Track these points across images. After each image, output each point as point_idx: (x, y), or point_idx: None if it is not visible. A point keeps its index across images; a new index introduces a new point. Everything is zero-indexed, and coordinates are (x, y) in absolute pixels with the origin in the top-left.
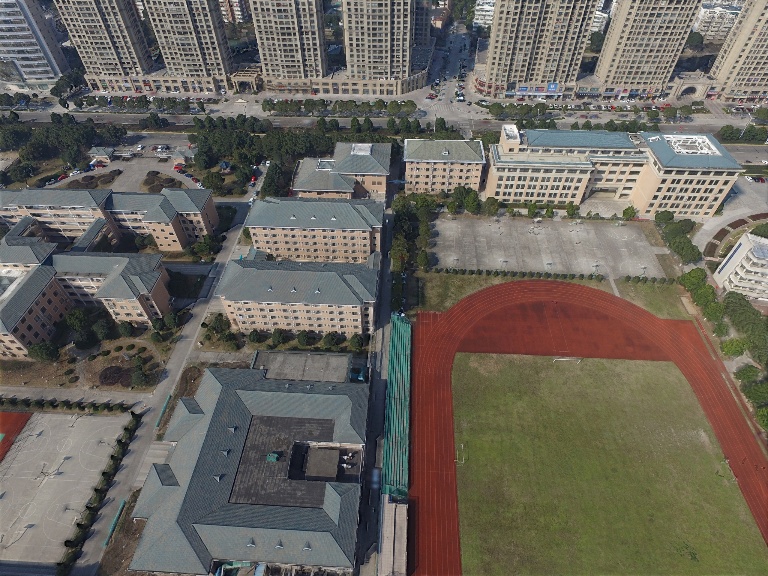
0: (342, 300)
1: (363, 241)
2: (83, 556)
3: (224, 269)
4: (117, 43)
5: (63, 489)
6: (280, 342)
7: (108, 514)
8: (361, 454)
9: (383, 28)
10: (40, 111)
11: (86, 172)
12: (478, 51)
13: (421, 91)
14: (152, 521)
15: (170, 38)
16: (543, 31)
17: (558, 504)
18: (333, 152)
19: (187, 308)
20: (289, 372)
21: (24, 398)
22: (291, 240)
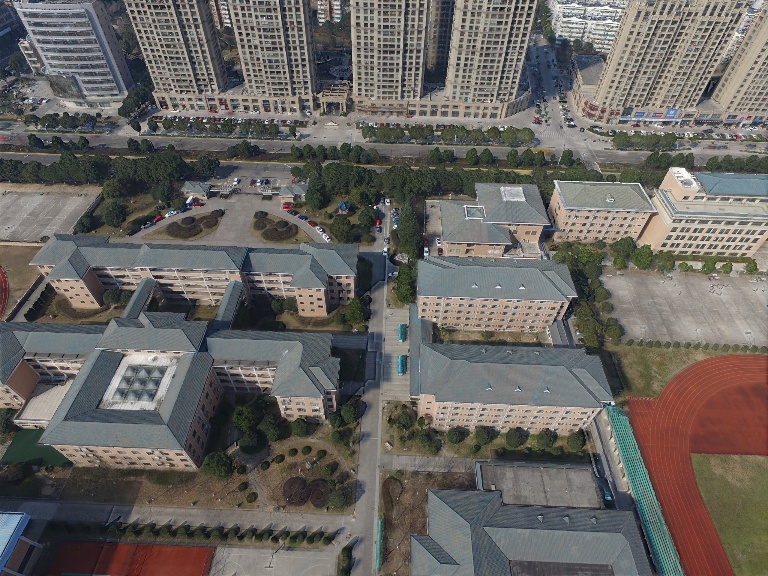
0: (577, 401)
1: (550, 311)
2: None
3: (383, 341)
4: (194, 58)
5: None
6: (486, 443)
7: None
8: None
9: (498, 48)
10: (107, 134)
11: (183, 212)
12: (579, 69)
13: (524, 114)
14: None
15: (256, 54)
16: (672, 54)
17: None
18: (461, 190)
19: (357, 395)
20: (528, 494)
21: (198, 525)
22: (465, 309)
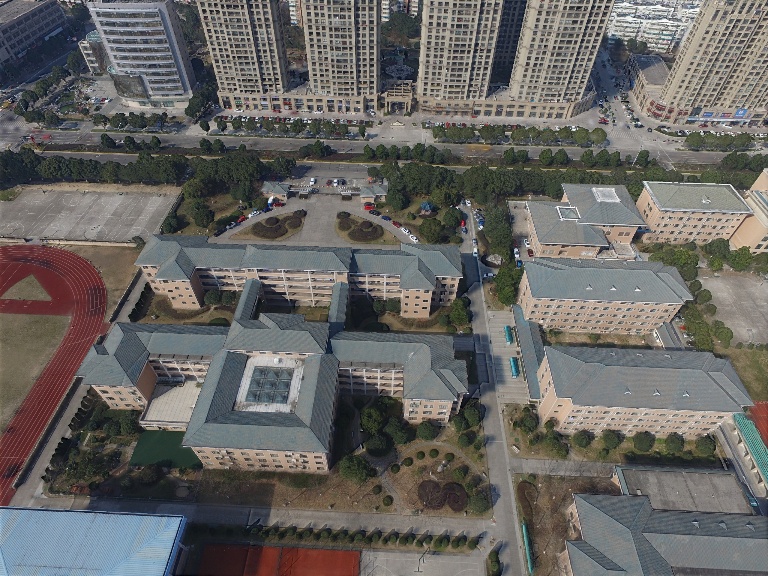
0: (718, 406)
1: (662, 314)
2: None
3: (489, 343)
4: (262, 58)
5: None
6: (615, 447)
7: None
8: None
9: (570, 47)
10: (175, 133)
11: (265, 212)
12: (640, 69)
13: (589, 114)
14: None
15: (324, 53)
16: (746, 53)
17: None
18: (542, 191)
19: (474, 397)
20: (676, 499)
21: (339, 528)
22: (576, 311)
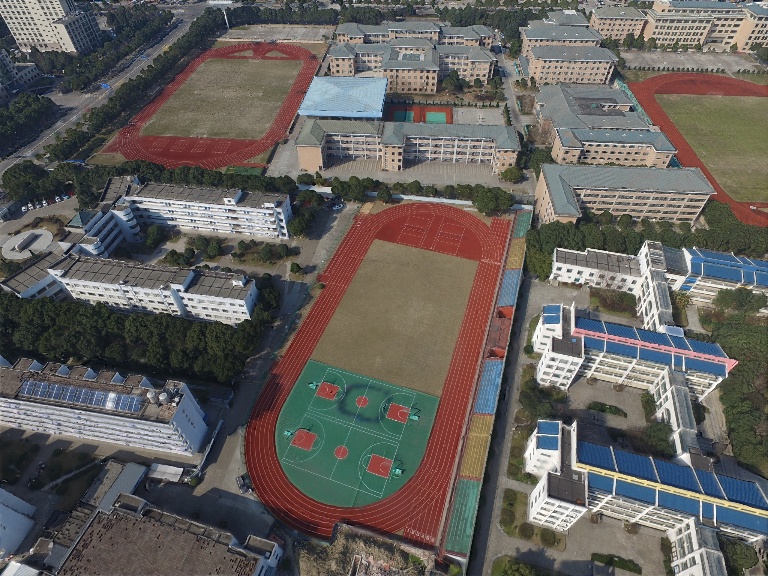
0: (603, 58)
1: None
2: None
3: (506, 68)
4: None
5: None
6: None
7: None
8: None
9: None
10: (321, 8)
11: None
12: None
13: None
14: (555, 117)
15: None
16: None
17: (725, 130)
18: None
19: None
20: None
21: None
22: None
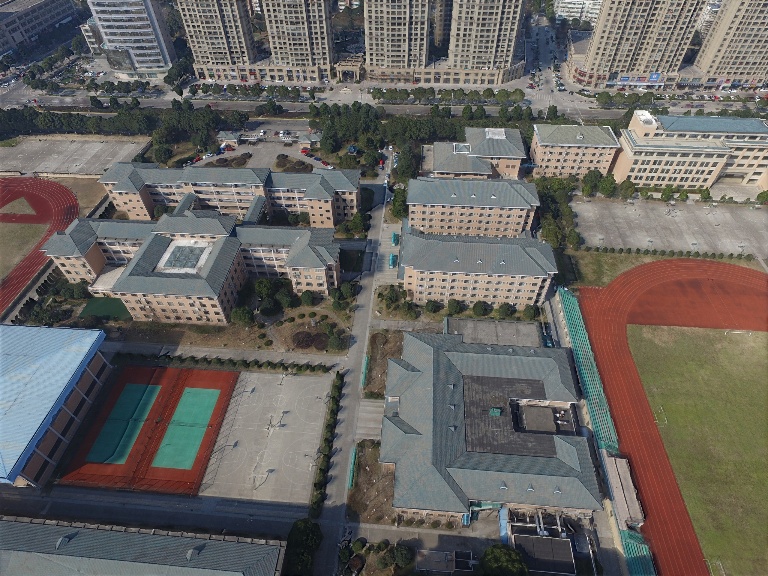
0: (527, 271)
1: (518, 219)
2: (329, 498)
3: (379, 245)
4: (229, 33)
5: (291, 439)
6: (456, 312)
7: (340, 462)
8: (570, 413)
9: (493, 18)
10: (154, 98)
11: (218, 155)
12: (572, 42)
13: (520, 81)
14: (402, 465)
15: (281, 28)
16: (652, 21)
17: (767, 462)
18: (455, 138)
19: (355, 280)
20: (483, 337)
21: (227, 358)
22: (447, 218)
